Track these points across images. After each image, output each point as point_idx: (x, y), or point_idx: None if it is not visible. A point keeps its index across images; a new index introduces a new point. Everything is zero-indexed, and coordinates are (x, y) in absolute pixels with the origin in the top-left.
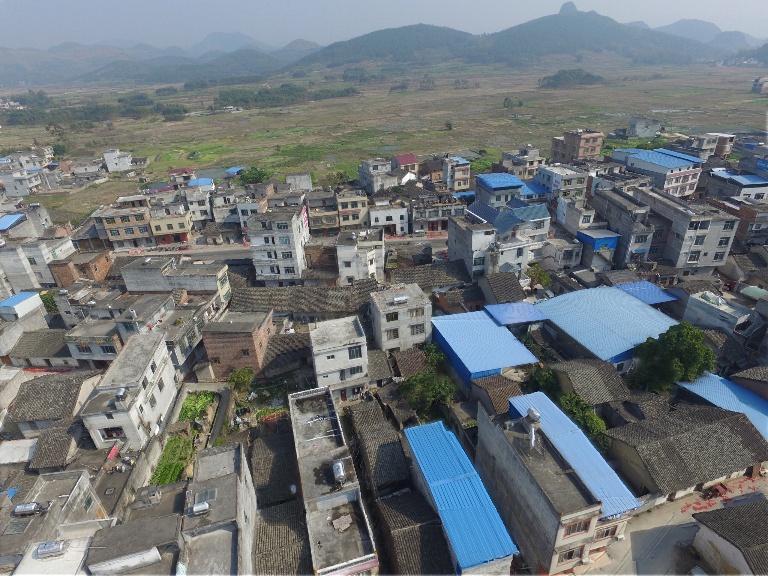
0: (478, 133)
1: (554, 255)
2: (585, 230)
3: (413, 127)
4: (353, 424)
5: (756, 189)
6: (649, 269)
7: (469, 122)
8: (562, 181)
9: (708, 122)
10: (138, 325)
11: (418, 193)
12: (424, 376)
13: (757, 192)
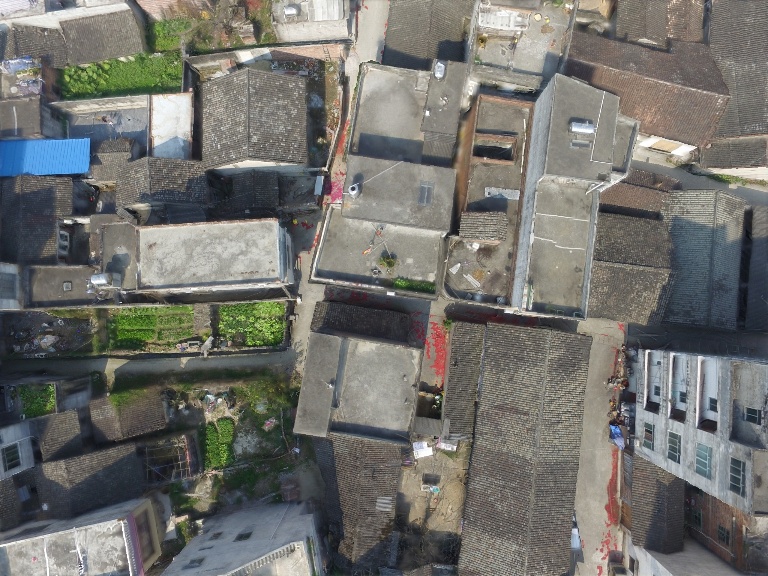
0: None
1: None
2: None
3: None
4: (159, 573)
5: None
6: None
7: None
8: None
9: None
10: None
11: None
12: None
13: None
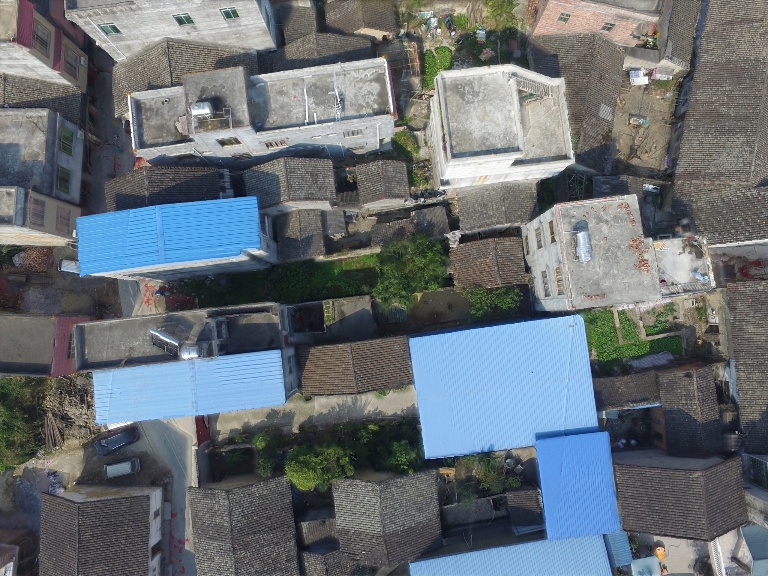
0: None
1: None
2: None
3: None
4: None
5: None
6: None
7: None
8: None
9: None
10: None
11: None
12: (419, 267)
13: None
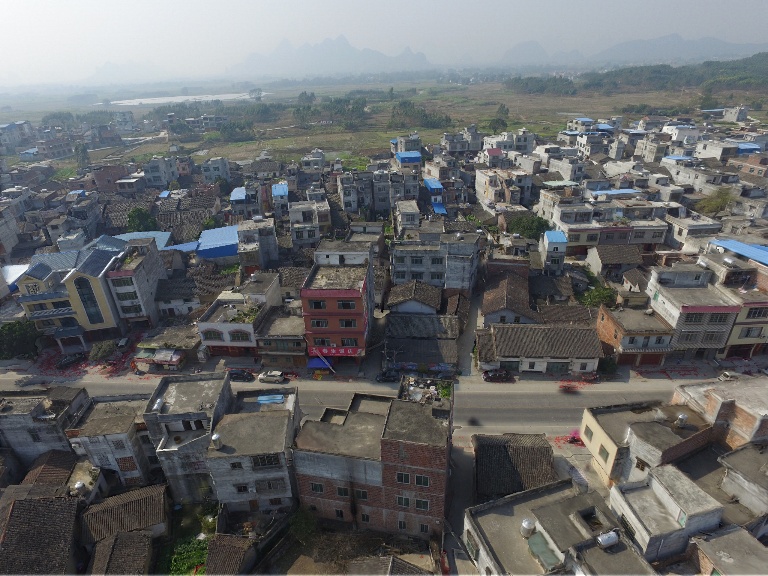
0: None
1: None
2: None
3: None
4: None
5: None
6: None
7: None
8: None
9: None
10: None
11: None
12: None
13: None
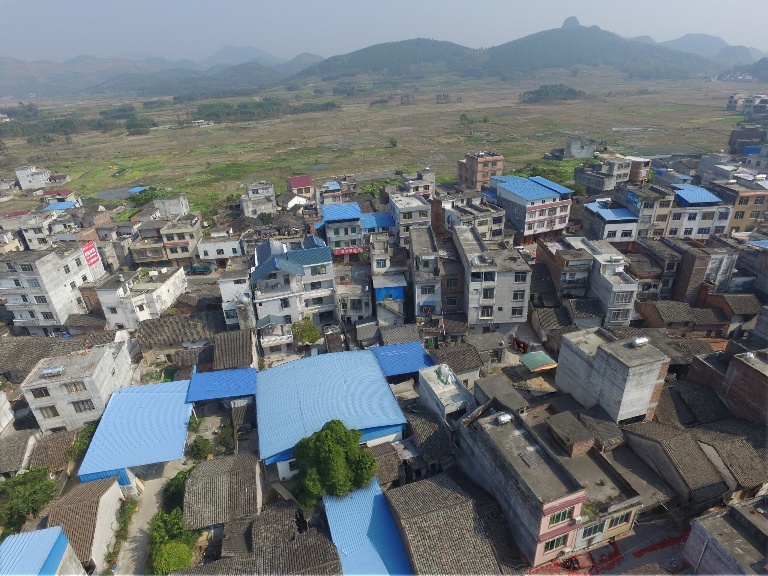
0: (420, 151)
1: (337, 305)
2: (380, 276)
3: (362, 144)
4: None
5: (622, 225)
6: (435, 325)
7: (421, 139)
8: (400, 214)
9: (659, 142)
10: None
11: (275, 222)
12: (22, 477)
13: (624, 228)
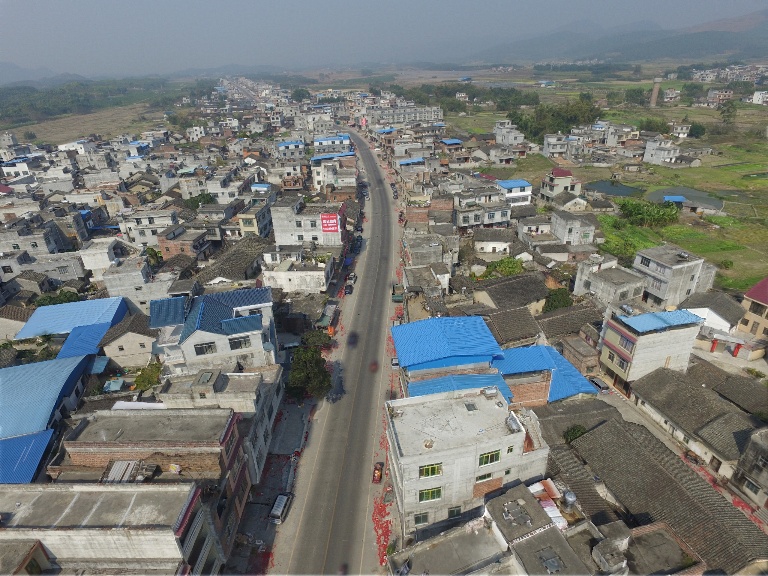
0: None
1: None
2: None
3: None
4: None
5: None
6: None
7: None
8: None
9: None
10: (198, 211)
11: None
12: (61, 293)
13: None
